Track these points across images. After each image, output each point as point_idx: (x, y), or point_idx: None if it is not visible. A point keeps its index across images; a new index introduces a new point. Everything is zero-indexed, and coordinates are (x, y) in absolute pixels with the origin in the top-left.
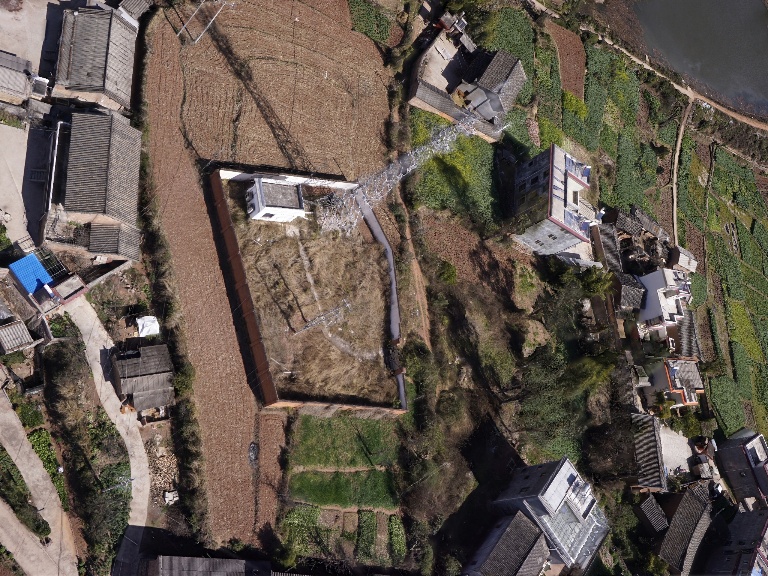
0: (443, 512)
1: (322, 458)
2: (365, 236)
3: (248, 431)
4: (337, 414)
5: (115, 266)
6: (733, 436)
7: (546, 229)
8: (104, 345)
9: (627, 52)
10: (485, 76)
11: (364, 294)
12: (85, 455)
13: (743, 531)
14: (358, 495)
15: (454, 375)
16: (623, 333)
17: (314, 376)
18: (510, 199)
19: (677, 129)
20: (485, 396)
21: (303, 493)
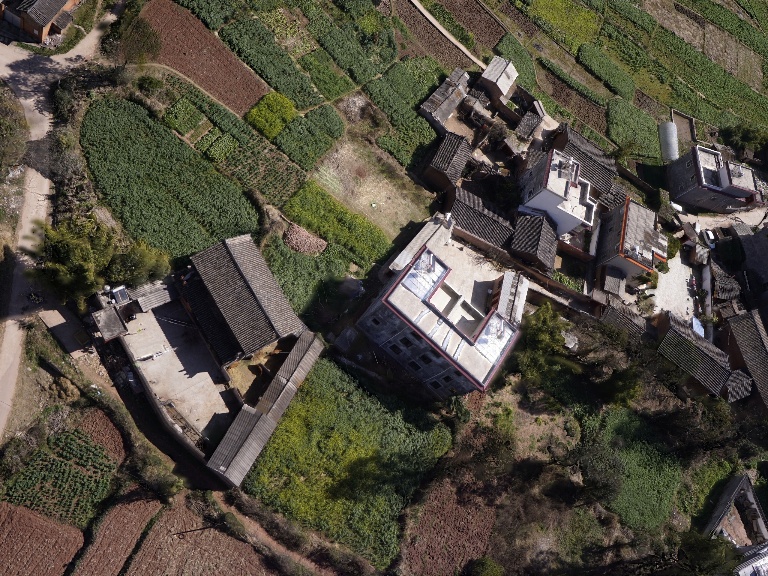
0: None
1: None
2: None
3: None
4: None
5: None
6: (664, 155)
7: None
8: None
9: None
10: (237, 332)
11: None
12: None
13: None
14: None
15: None
16: (556, 258)
17: None
18: (398, 370)
19: None
20: None
21: None
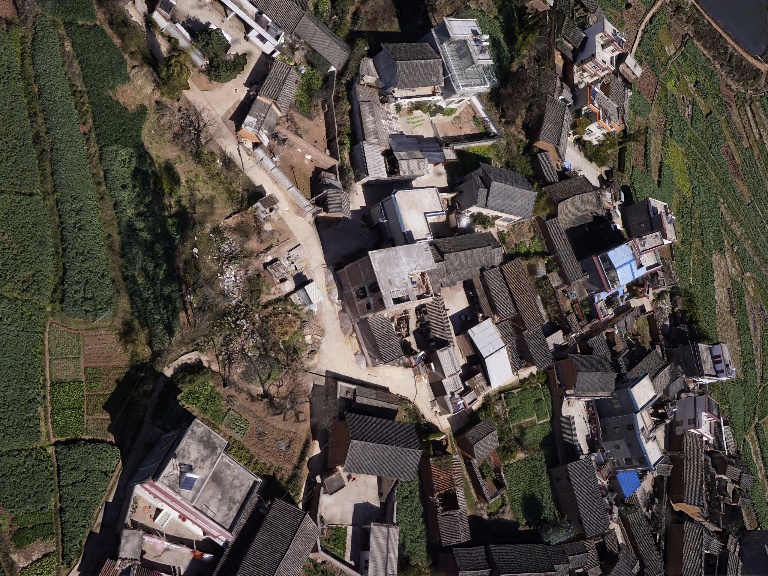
0: (366, 25)
1: None
2: None
3: None
4: None
5: None
6: None
7: None
8: None
9: None
10: None
11: None
12: None
13: None
14: None
15: None
16: None
17: None
18: None
19: (654, 1)
20: None
21: None
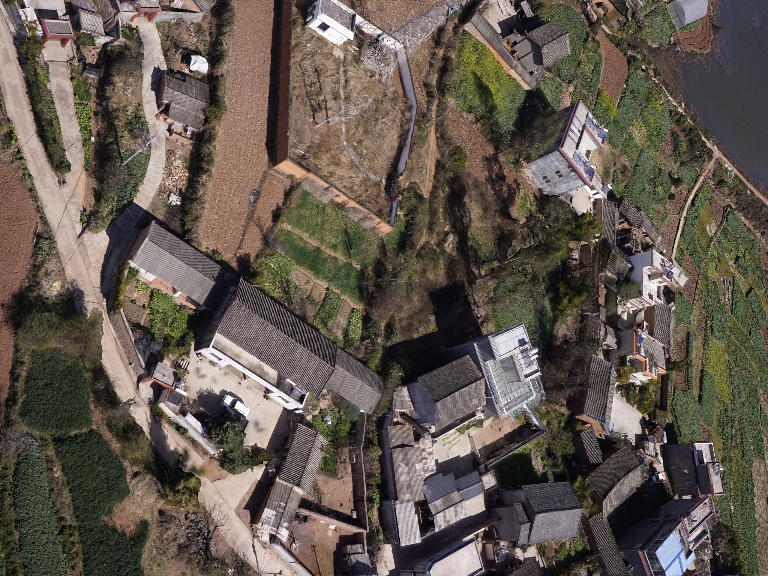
0: (400, 334)
1: (310, 229)
2: (397, 90)
3: (254, 179)
4: (333, 205)
5: (187, 11)
6: None
7: (555, 163)
8: (159, 65)
9: (666, 91)
10: (534, 32)
11: (383, 128)
12: (117, 132)
13: (673, 509)
14: (331, 275)
15: (442, 232)
16: (603, 301)
17: (322, 165)
18: None
19: (697, 177)
20: (464, 267)
21: (285, 246)
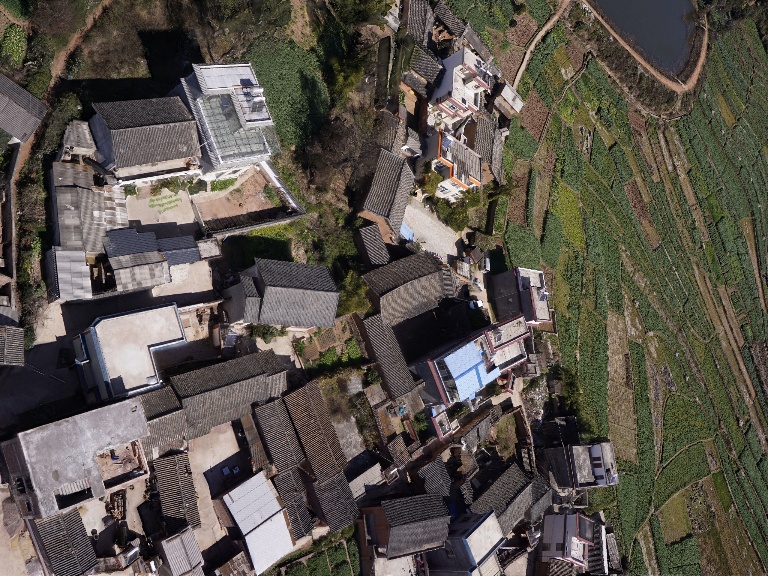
0: (91, 70)
1: None
2: None
3: None
4: None
5: None
6: None
7: None
8: None
9: None
10: None
11: None
12: None
13: None
14: None
15: None
16: (412, 109)
17: None
18: None
19: (550, 15)
20: (196, 16)
21: None
